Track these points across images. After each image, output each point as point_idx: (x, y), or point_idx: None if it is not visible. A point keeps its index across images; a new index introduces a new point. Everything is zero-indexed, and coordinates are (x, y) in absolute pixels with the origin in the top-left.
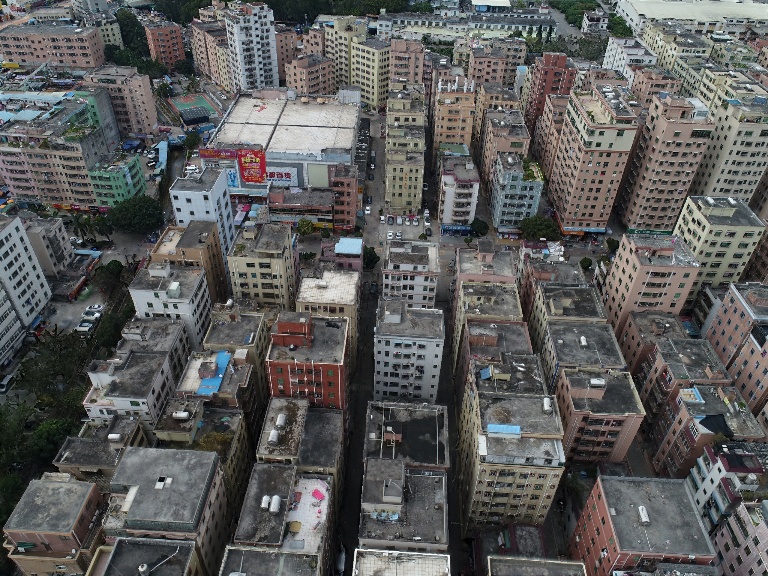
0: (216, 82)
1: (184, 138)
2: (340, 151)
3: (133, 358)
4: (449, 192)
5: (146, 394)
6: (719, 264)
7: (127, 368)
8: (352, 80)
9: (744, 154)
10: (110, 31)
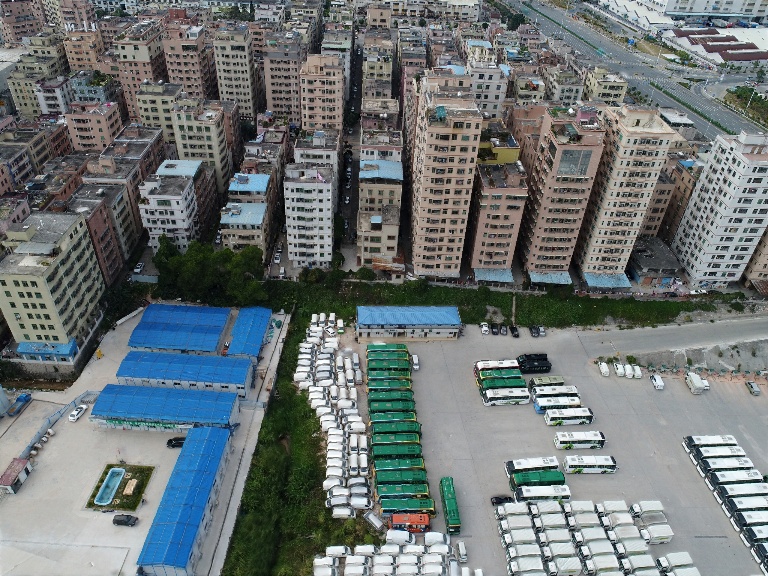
0: None
1: None
2: None
3: None
4: (40, 96)
5: None
6: (160, 126)
7: None
8: None
9: (228, 64)
10: None
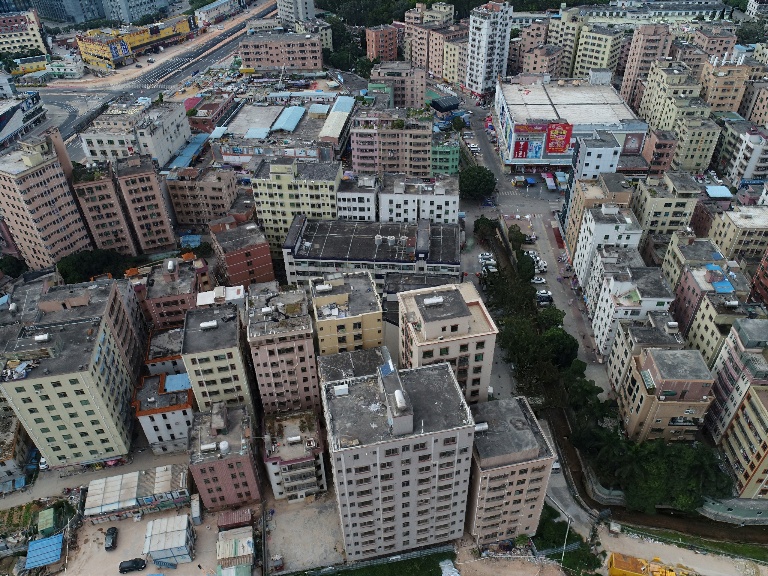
0: (434, 76)
1: (447, 123)
2: (636, 121)
3: (633, 273)
4: (757, 149)
5: (672, 295)
6: None
7: (636, 279)
8: (576, 66)
9: None
10: (324, 36)
